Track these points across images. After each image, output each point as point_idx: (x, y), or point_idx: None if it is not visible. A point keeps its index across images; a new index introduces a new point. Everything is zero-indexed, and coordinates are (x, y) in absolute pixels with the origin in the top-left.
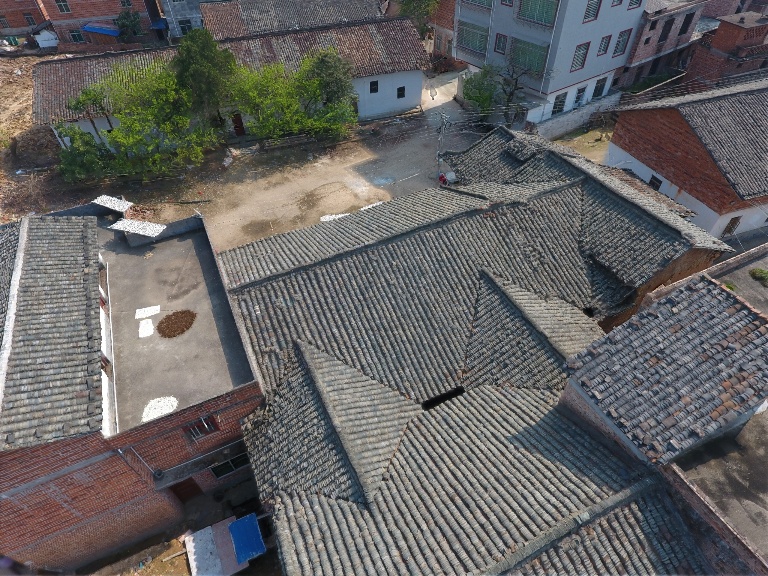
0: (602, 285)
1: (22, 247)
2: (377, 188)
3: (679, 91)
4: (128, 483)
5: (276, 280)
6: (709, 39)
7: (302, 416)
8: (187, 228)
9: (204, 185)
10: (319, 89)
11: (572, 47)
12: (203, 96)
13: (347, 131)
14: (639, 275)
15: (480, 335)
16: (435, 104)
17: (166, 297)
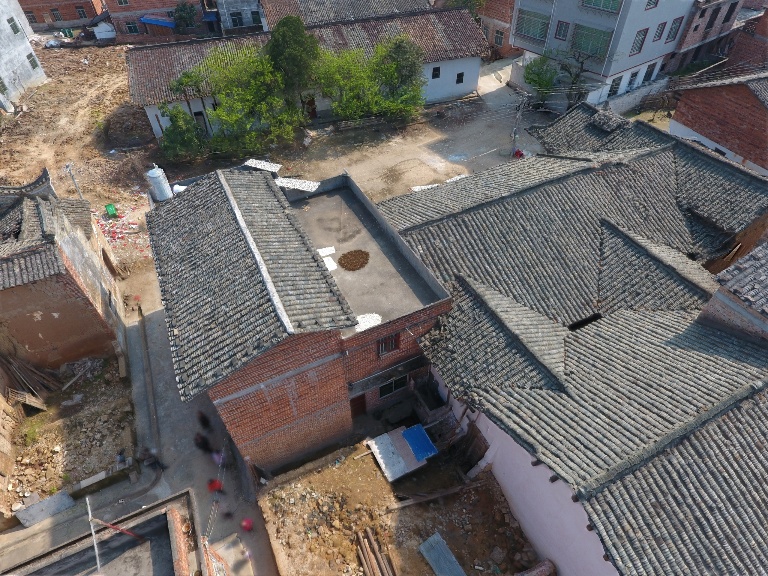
0: (701, 234)
1: (230, 192)
2: (453, 164)
3: (730, 73)
4: (336, 387)
5: (432, 225)
6: (753, 26)
7: (480, 331)
8: (334, 186)
9: (290, 162)
10: (396, 73)
11: (633, 33)
12: (295, 78)
13: (414, 114)
14: (738, 223)
15: (609, 271)
16: (490, 89)
17: (336, 240)
